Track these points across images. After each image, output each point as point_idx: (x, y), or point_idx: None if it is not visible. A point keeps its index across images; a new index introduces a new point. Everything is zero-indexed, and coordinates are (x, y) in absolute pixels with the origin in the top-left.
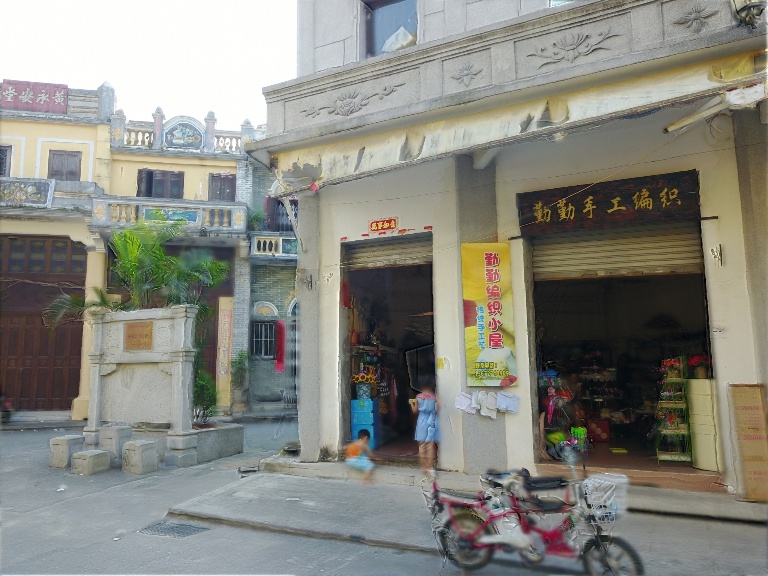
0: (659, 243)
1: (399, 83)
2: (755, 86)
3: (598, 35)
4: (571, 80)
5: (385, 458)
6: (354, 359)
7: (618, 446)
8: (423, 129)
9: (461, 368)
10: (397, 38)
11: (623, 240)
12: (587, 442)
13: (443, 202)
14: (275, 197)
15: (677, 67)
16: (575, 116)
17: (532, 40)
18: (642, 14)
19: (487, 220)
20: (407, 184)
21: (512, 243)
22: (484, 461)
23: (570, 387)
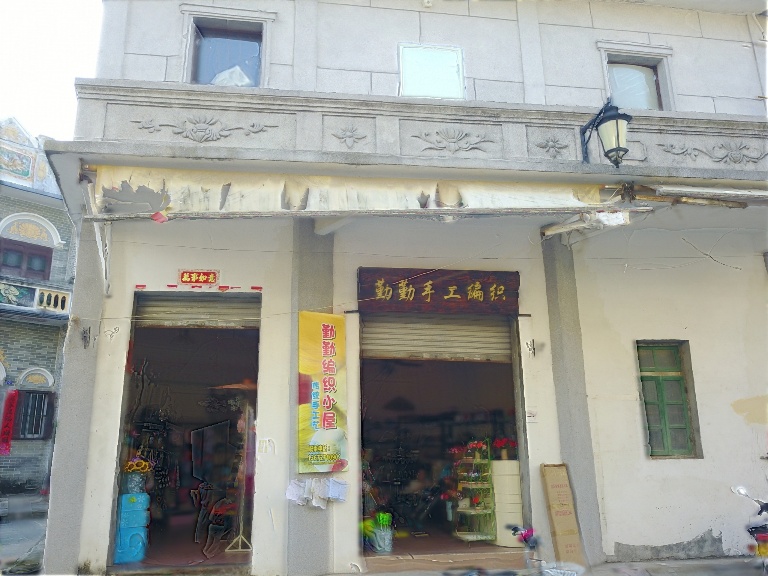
0: (479, 332)
1: (270, 124)
2: (616, 213)
3: (475, 136)
4: (463, 170)
5: (177, 570)
6: (134, 440)
7: (417, 530)
8: (306, 180)
9: (292, 451)
10: (231, 76)
11: (448, 326)
12: (392, 528)
13: (277, 262)
14: (92, 219)
15: (548, 182)
16: (473, 204)
17: (416, 123)
18: (512, 130)
19: (324, 289)
20: (242, 235)
21: (348, 317)
22: (312, 561)
23: (372, 470)
